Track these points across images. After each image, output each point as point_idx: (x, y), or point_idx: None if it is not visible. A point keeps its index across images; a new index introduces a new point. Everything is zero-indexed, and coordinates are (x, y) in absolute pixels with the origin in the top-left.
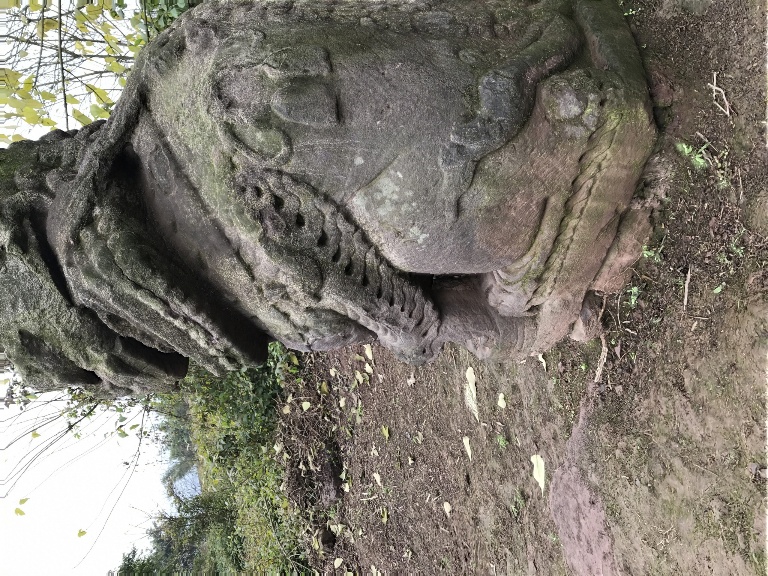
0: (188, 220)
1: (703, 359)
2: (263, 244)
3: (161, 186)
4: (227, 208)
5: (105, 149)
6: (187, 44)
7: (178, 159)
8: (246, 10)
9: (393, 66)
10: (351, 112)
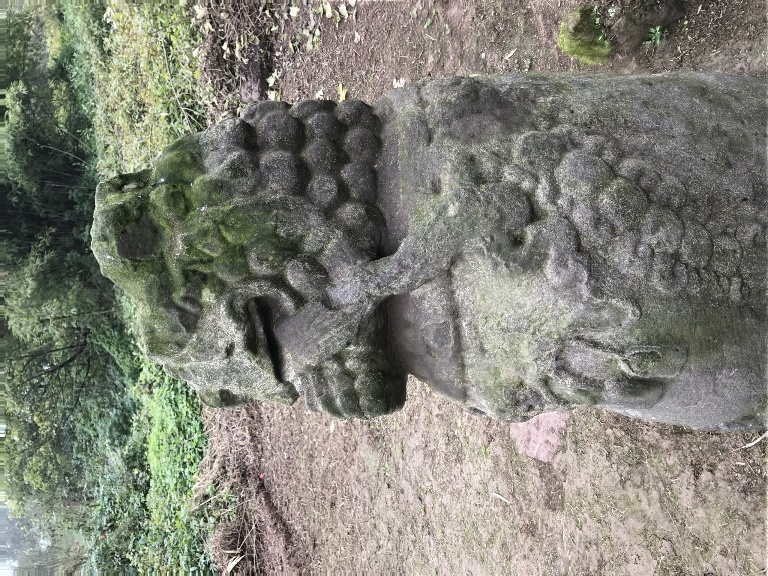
0: (439, 375)
1: (729, 488)
2: (501, 419)
3: (426, 341)
4: (490, 400)
5: (383, 295)
6: (547, 268)
7: (463, 342)
8: (634, 253)
9: (729, 372)
10: (664, 400)
